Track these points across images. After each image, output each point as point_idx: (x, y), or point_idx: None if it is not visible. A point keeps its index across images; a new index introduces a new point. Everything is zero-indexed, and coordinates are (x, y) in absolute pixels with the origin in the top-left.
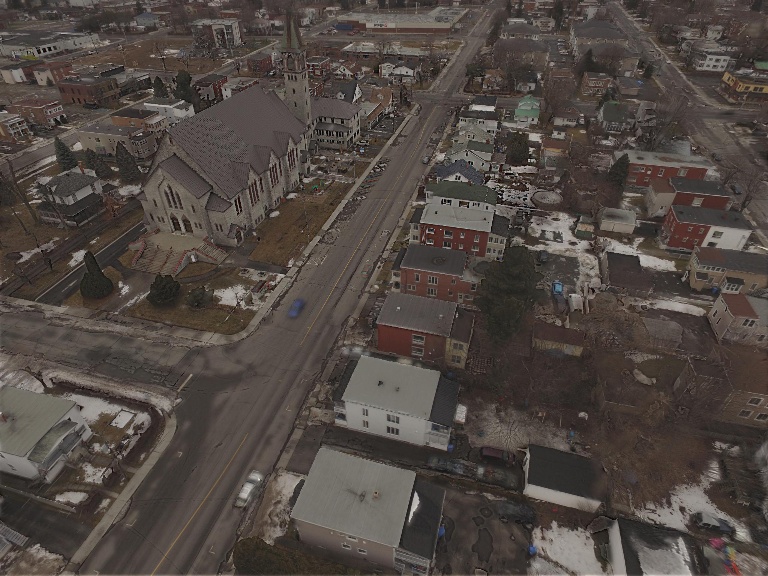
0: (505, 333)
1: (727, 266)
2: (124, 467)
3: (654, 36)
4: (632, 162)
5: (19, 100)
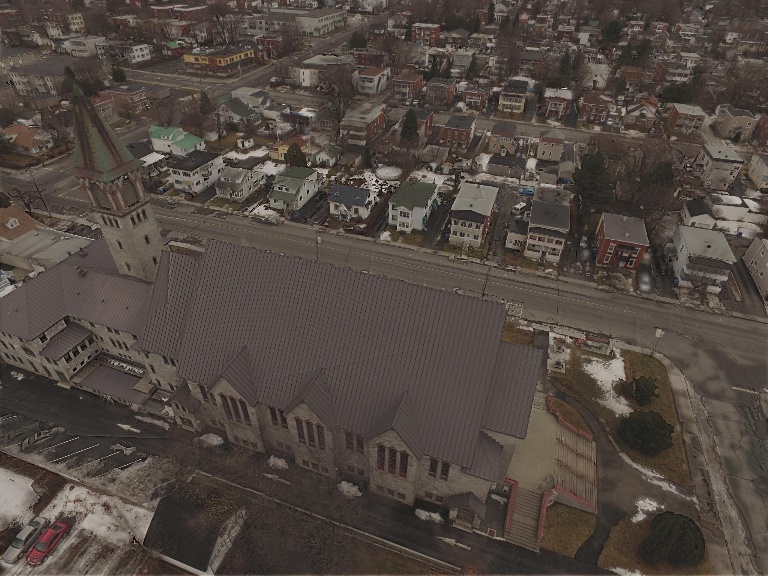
0: None
1: (513, 134)
2: None
3: None
4: (370, 122)
5: None
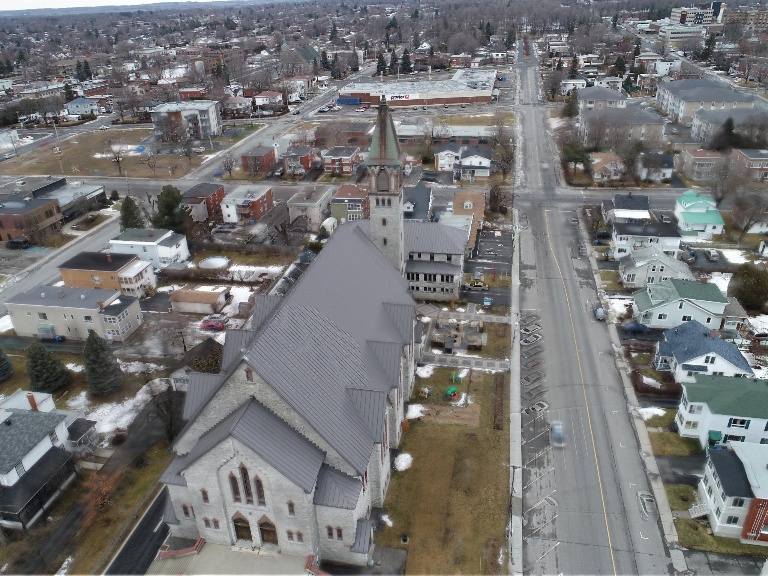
0: None
1: None
2: None
3: None
4: None
5: None
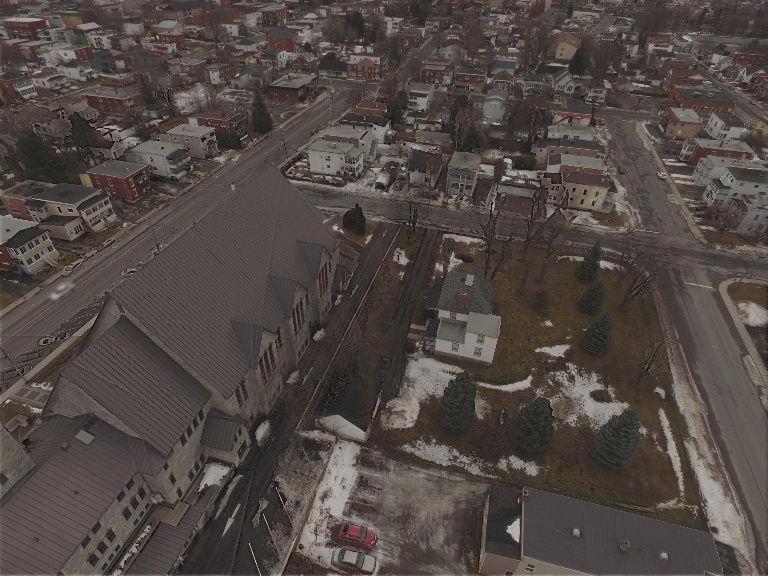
0: None
1: None
2: (291, 164)
3: None
4: None
5: None
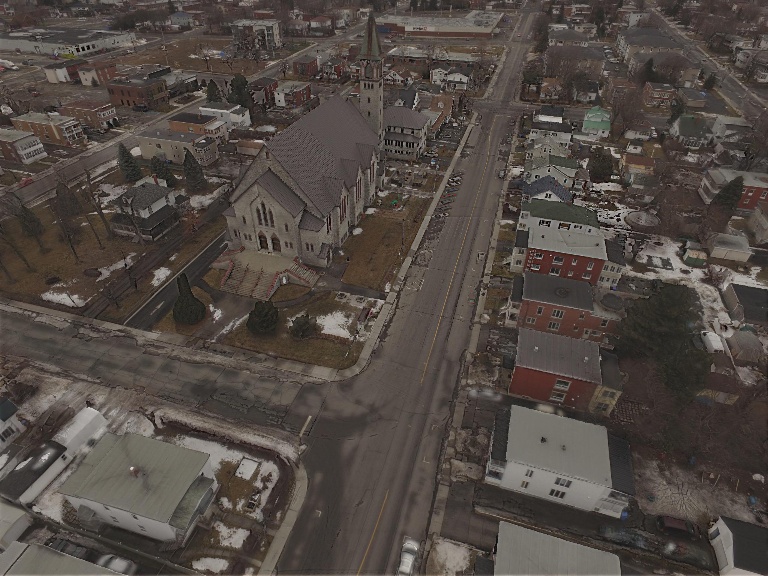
0: (691, 389)
1: None
2: (261, 528)
3: (702, 45)
4: None
5: (66, 101)
